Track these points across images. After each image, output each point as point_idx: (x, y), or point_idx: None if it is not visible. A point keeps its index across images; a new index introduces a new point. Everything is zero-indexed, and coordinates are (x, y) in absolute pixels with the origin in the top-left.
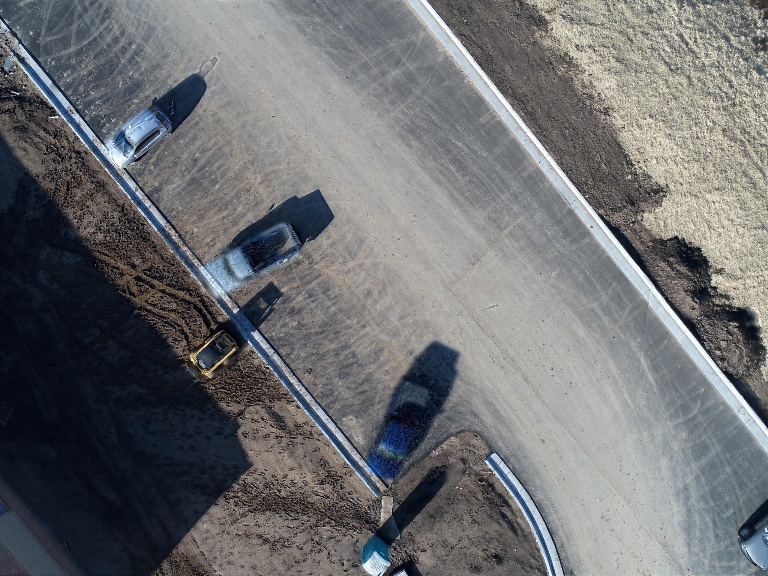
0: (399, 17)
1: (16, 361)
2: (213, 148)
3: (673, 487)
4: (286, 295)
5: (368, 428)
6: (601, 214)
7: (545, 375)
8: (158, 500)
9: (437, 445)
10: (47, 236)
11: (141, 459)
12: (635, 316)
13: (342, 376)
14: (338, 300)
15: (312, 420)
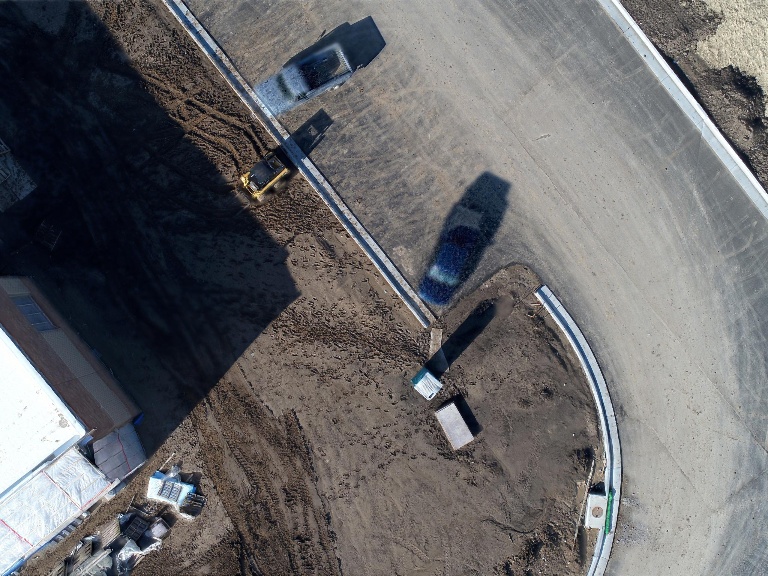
0: None
1: (64, 184)
2: None
3: (725, 322)
4: (337, 122)
5: (418, 258)
6: (655, 42)
7: (597, 207)
8: (206, 328)
9: (487, 277)
10: (97, 58)
11: (189, 285)
12: (688, 147)
13: (392, 205)
14: (389, 129)
15: (362, 249)
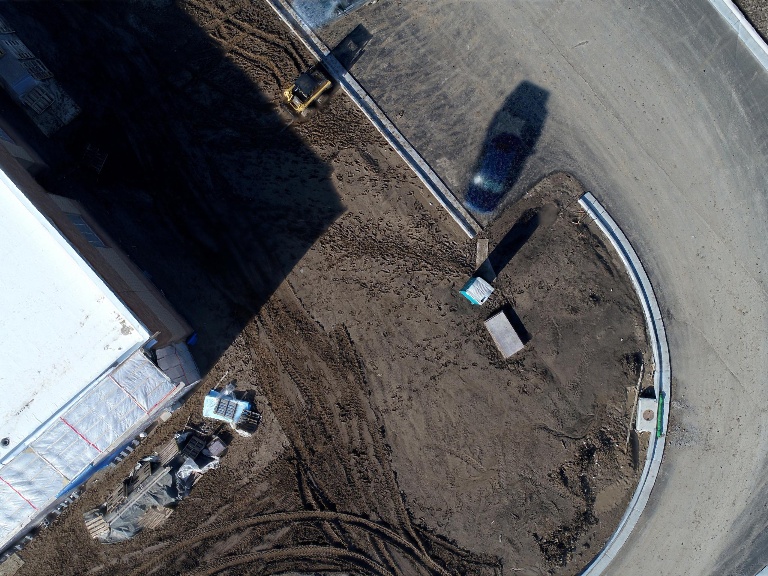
0: None
1: (109, 108)
2: None
3: (767, 221)
4: (376, 37)
5: (461, 170)
6: None
7: (637, 111)
8: (254, 246)
9: (530, 186)
10: None
11: (236, 204)
12: (725, 48)
13: (434, 118)
14: (428, 41)
15: (406, 161)
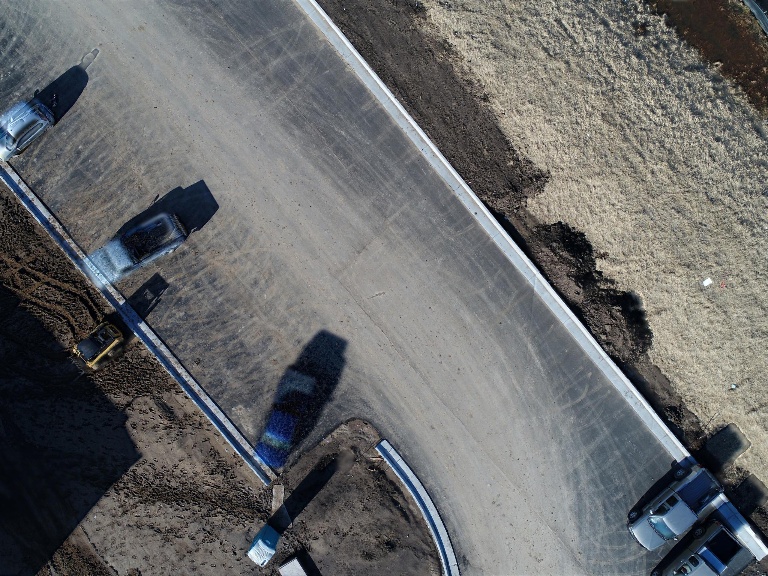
0: (279, 6)
1: None
2: (96, 140)
3: (563, 471)
4: (172, 286)
5: (257, 417)
6: (485, 200)
7: (433, 362)
8: (47, 493)
9: (327, 433)
10: None
11: (29, 452)
12: (521, 302)
13: (230, 366)
14: (225, 290)
15: (200, 410)
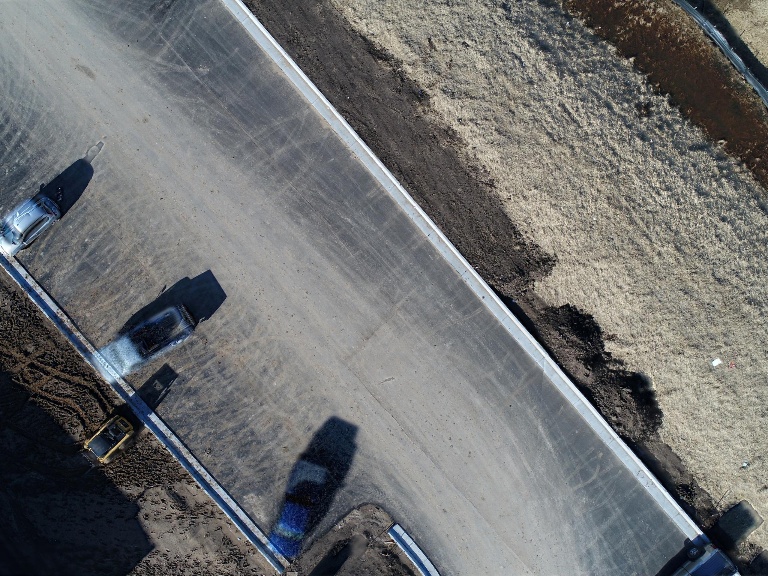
0: (283, 96)
1: None
2: (102, 232)
3: (576, 551)
4: (181, 376)
5: (269, 505)
6: (492, 284)
7: (444, 445)
8: None
9: (339, 519)
10: None
11: (42, 546)
12: (531, 384)
13: (241, 454)
14: (234, 379)
15: (212, 500)
